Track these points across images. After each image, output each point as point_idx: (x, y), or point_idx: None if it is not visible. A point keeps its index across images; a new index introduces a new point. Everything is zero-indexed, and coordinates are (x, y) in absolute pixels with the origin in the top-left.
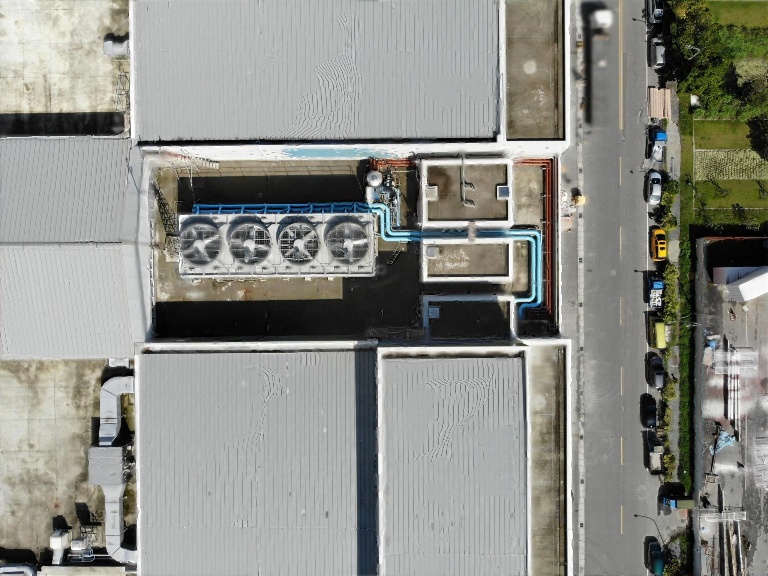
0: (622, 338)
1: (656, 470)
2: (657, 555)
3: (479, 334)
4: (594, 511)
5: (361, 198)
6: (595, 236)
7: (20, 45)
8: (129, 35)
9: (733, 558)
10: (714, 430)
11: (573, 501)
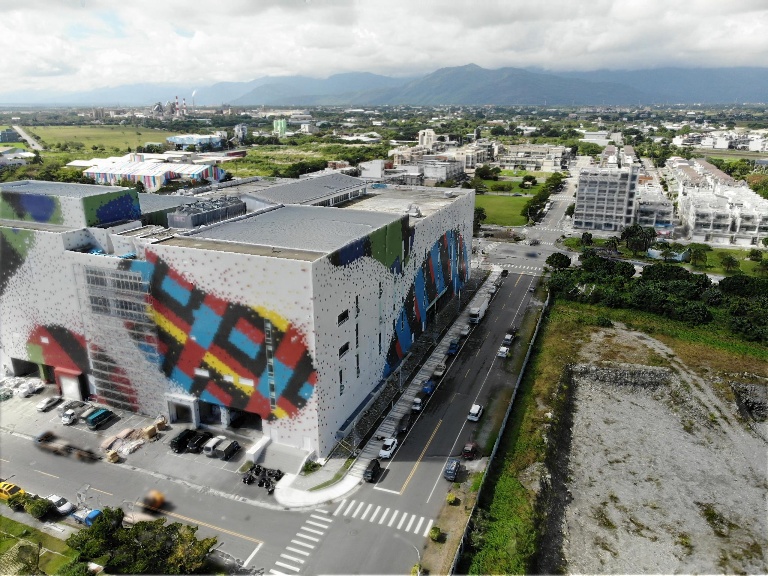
0: None
1: None
2: None
3: (105, 226)
4: None
5: None
6: (75, 462)
7: None
8: None
9: None
10: None
11: None
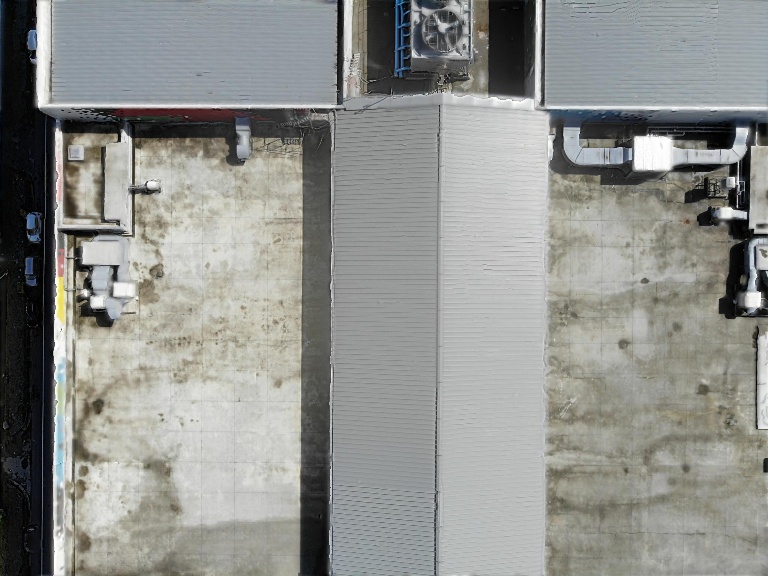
0: None
1: None
2: None
3: None
4: None
5: None
6: None
7: (237, 247)
8: (236, 109)
9: None
10: None
11: None
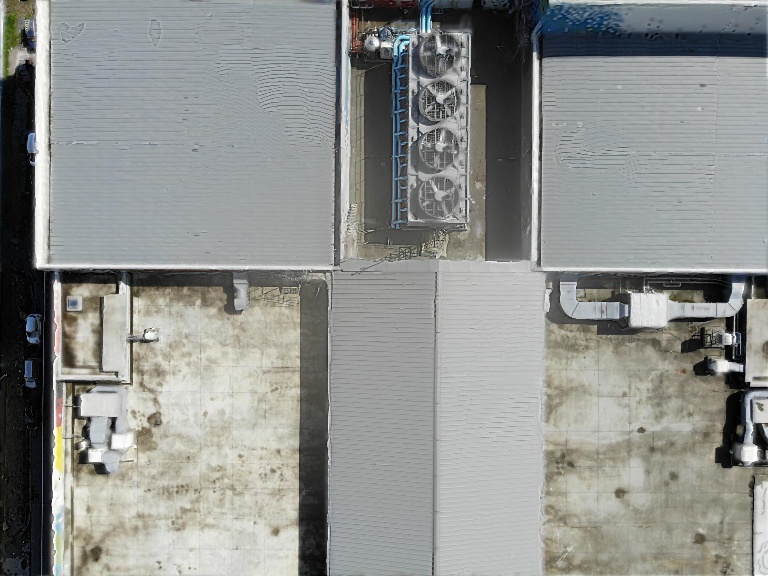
0: None
1: None
2: None
3: None
4: None
5: (388, 66)
6: None
7: (234, 396)
8: (233, 270)
9: None
10: None
11: None
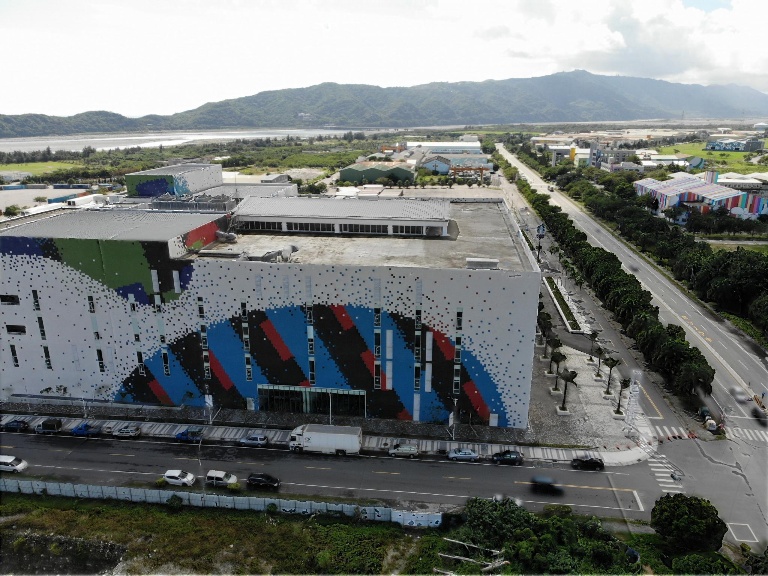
0: None
1: None
2: None
3: None
4: None
5: None
6: None
7: None
8: None
9: None
10: None
11: None
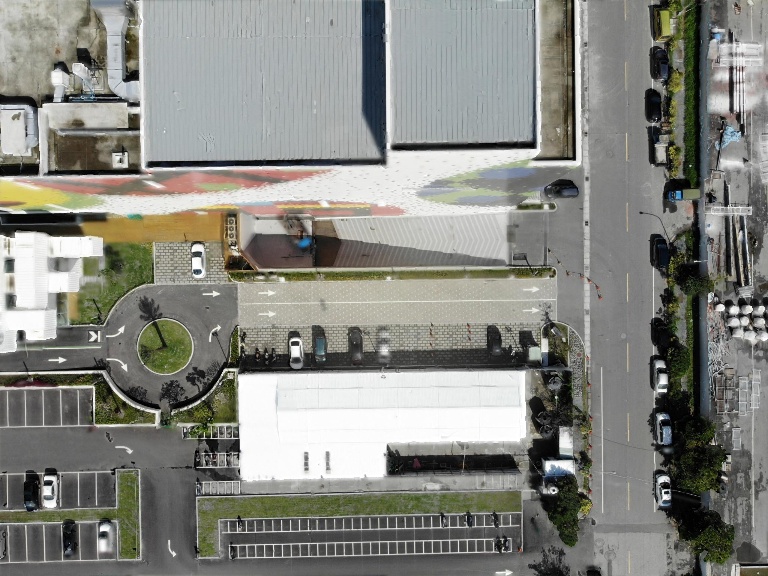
0: (626, 33)
1: (661, 163)
2: (663, 248)
3: None
4: (599, 209)
5: None
6: None
7: None
8: None
9: (739, 253)
10: (719, 125)
11: (578, 198)
